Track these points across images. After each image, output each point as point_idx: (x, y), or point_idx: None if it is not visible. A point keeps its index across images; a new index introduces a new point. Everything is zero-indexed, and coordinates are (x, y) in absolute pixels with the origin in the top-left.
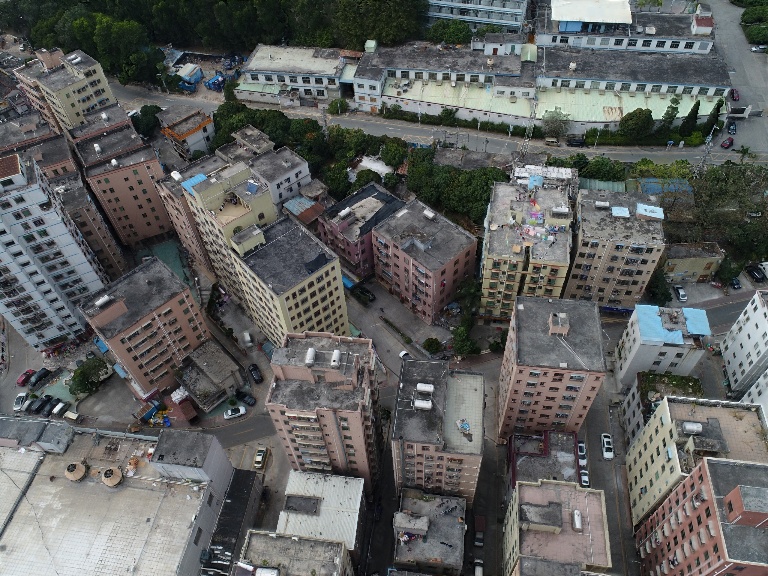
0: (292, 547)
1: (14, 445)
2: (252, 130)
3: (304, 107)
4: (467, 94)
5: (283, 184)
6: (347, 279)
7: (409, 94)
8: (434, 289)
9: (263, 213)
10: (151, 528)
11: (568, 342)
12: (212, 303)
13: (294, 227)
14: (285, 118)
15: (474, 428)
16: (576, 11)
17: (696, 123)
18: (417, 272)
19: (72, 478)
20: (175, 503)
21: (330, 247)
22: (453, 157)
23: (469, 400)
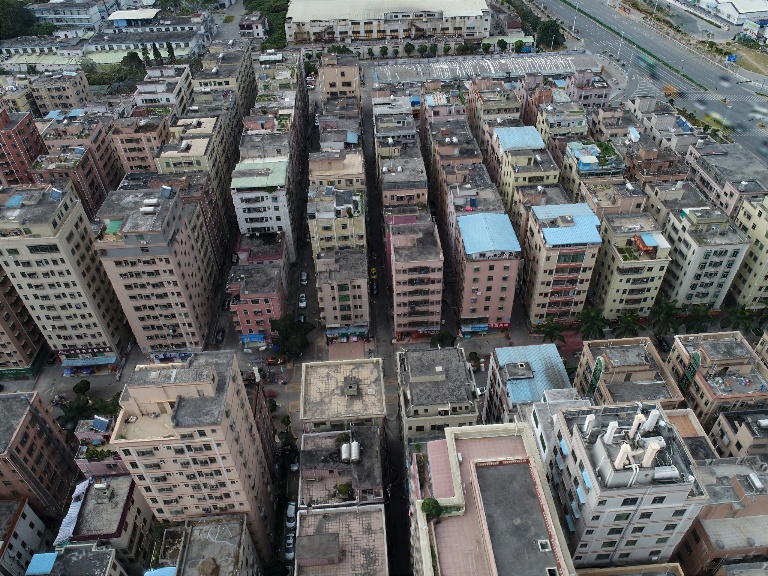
0: None
1: None
2: None
3: None
4: (44, 58)
5: None
6: None
7: (8, 61)
8: None
9: None
10: None
11: None
12: None
13: None
14: None
15: None
16: (124, 15)
17: None
18: None
19: None
20: None
21: None
22: None
23: None
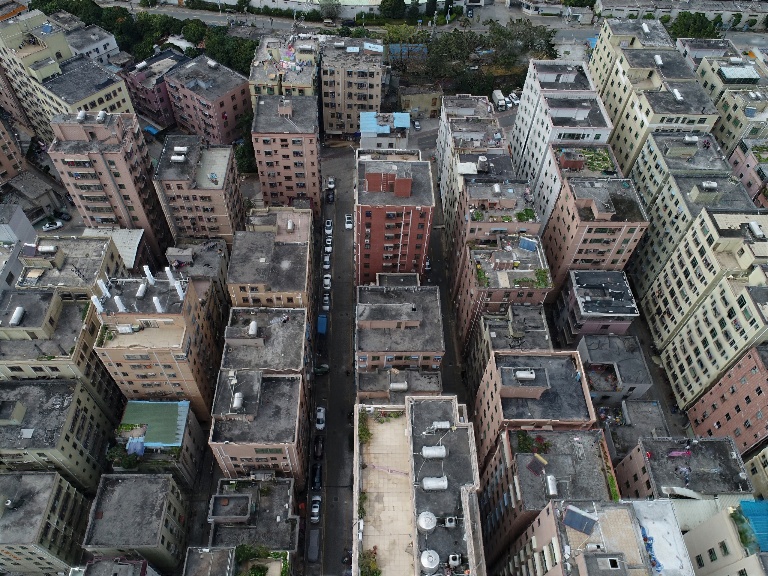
0: (72, 244)
1: None
2: (64, 14)
3: (118, 2)
4: None
5: (92, 53)
6: (153, 128)
7: None
8: (216, 119)
9: (60, 53)
10: None
11: (292, 120)
12: (32, 152)
13: (88, 63)
14: (97, 6)
15: (220, 177)
16: None
17: (441, 7)
18: (201, 106)
19: None
20: None
21: (135, 101)
22: (243, 32)
23: (219, 162)
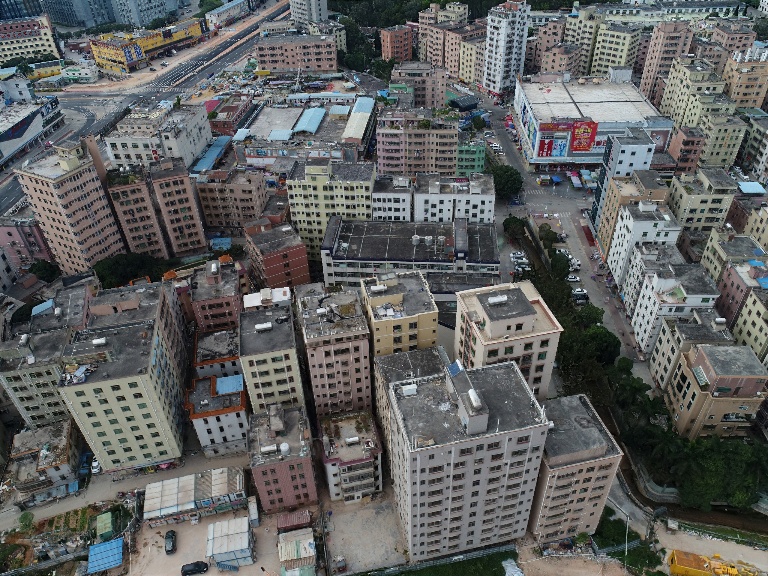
0: None
1: (551, 80)
2: None
3: None
4: (630, 17)
5: None
6: None
7: None
8: None
9: None
10: (620, 88)
11: None
12: None
13: None
14: None
15: None
16: None
17: None
18: None
19: (583, 81)
20: (622, 85)
21: None
22: None
23: None
